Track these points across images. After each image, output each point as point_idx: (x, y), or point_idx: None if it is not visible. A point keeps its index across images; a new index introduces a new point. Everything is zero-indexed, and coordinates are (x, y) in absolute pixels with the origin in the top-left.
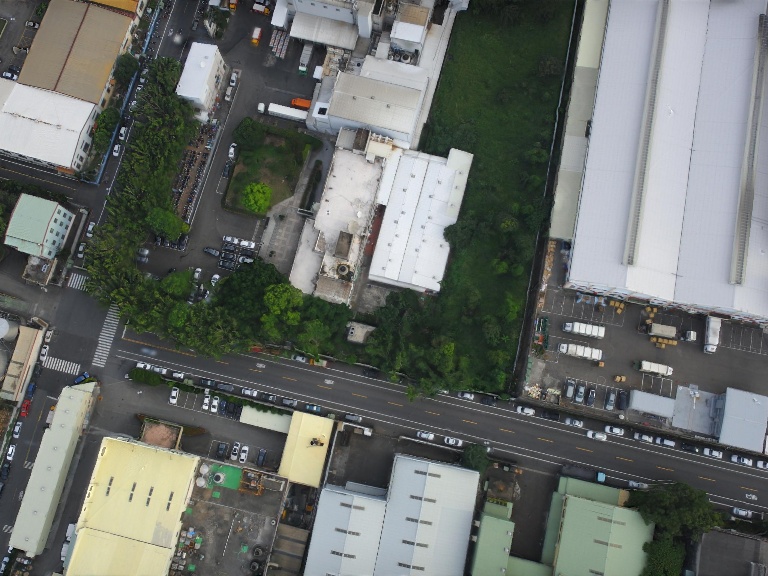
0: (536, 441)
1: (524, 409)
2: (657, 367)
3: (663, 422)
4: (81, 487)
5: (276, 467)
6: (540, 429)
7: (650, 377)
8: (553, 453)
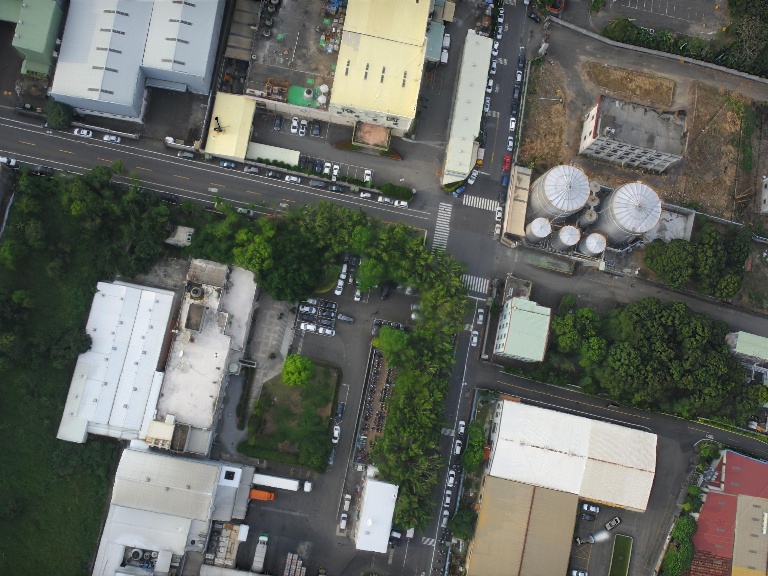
0: None
1: (7, 161)
2: None
3: None
4: (443, 95)
5: (264, 116)
6: None
7: None
8: None
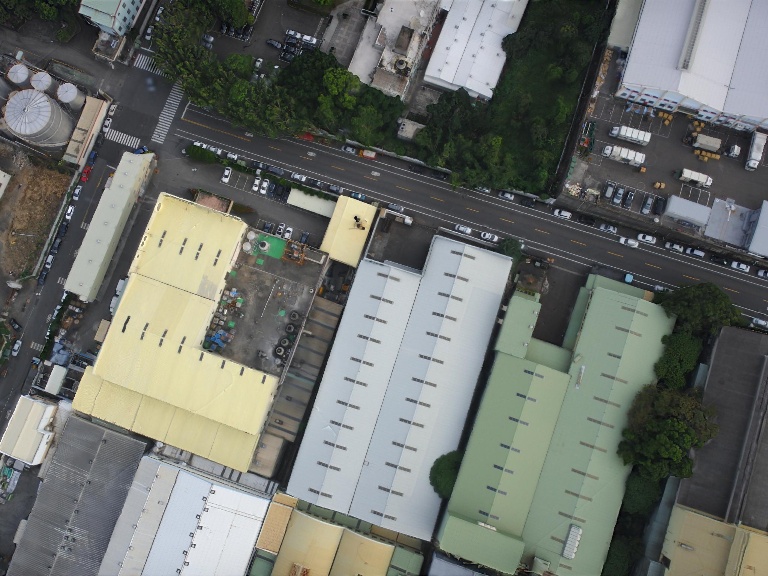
0: (569, 243)
1: (561, 211)
2: (697, 176)
3: (696, 230)
4: (133, 250)
5: None
6: (575, 232)
7: (689, 187)
8: (584, 255)
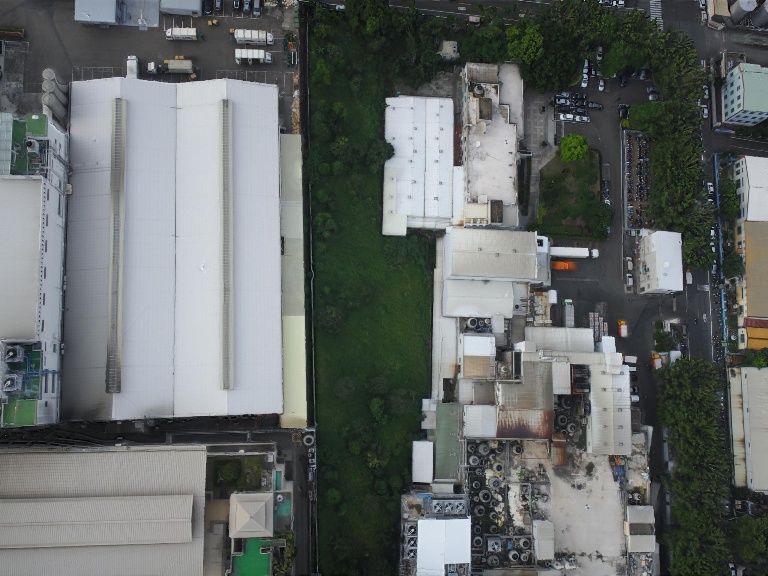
0: None
1: None
2: (182, 32)
3: None
4: None
5: None
6: None
7: None
8: None
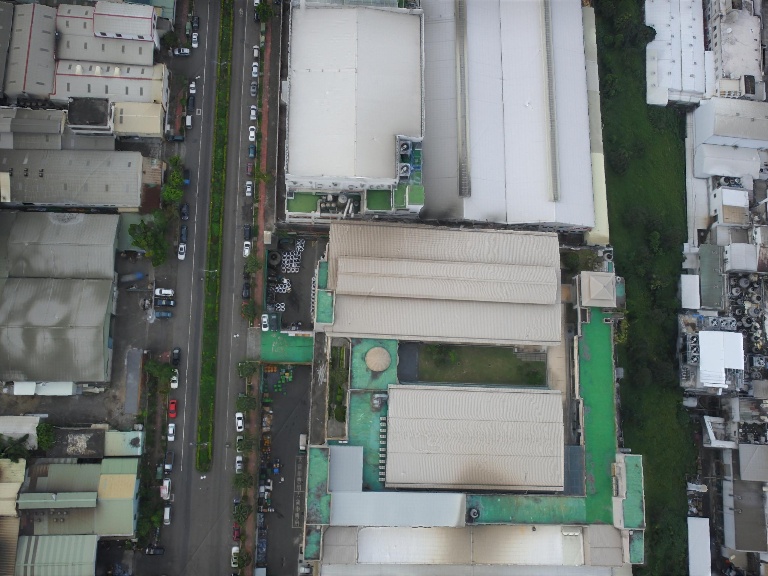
0: None
1: None
2: None
3: None
4: None
5: None
6: None
7: None
8: None
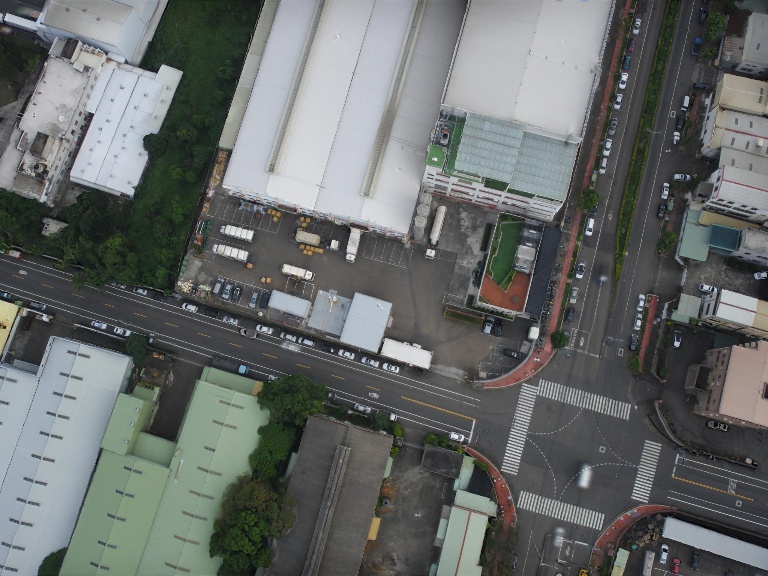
0: (195, 335)
1: (187, 305)
2: (296, 270)
3: (300, 322)
4: None
5: None
6: (201, 325)
7: (295, 281)
8: (208, 347)
